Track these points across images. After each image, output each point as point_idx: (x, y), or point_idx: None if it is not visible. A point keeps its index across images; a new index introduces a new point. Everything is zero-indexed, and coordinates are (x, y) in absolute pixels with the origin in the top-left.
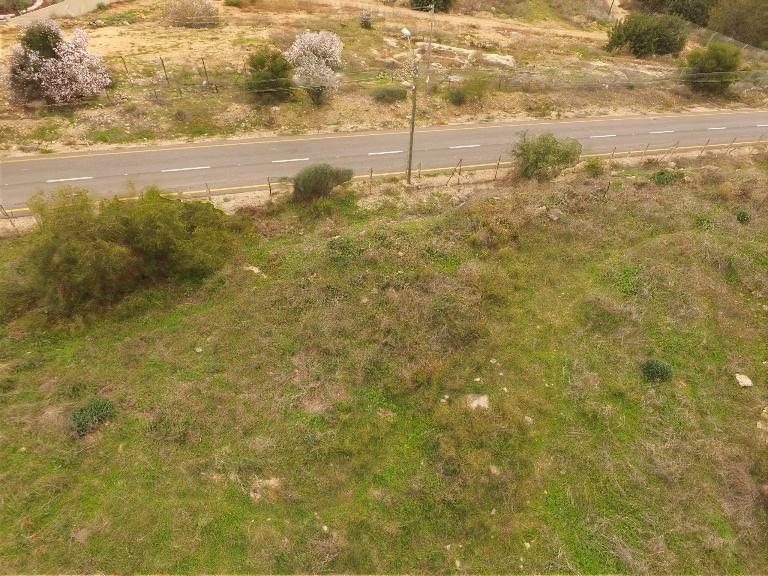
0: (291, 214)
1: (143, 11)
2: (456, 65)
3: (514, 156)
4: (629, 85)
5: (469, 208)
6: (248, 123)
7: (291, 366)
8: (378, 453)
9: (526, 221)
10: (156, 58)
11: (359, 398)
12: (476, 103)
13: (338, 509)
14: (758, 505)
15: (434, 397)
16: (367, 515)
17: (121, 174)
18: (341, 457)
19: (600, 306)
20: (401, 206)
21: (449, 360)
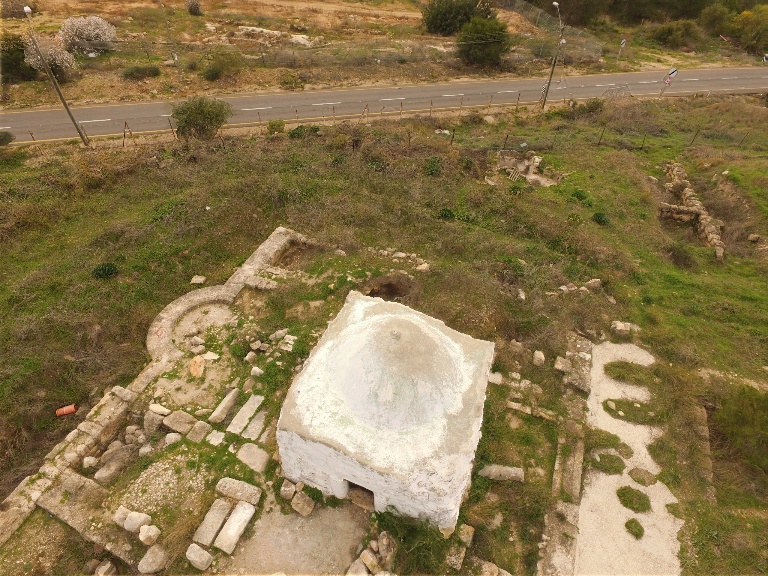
0: None
1: None
2: None
3: None
4: (401, 59)
5: None
6: None
7: None
8: None
9: (127, 168)
10: None
11: None
12: (231, 78)
13: None
14: None
15: None
16: None
17: None
18: None
19: None
20: (67, 164)
21: None
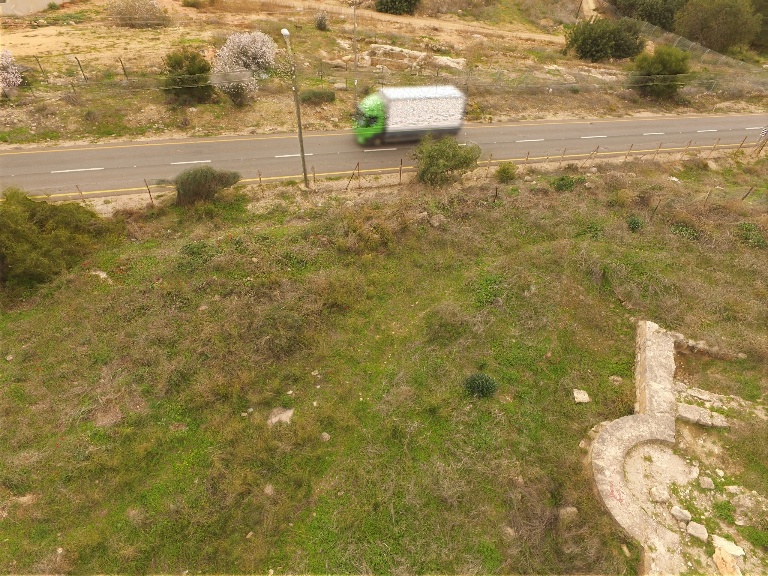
0: (173, 217)
1: (95, 11)
2: (404, 67)
3: (416, 160)
4: (574, 89)
5: (345, 213)
6: (161, 124)
7: (98, 376)
8: (151, 470)
9: (402, 227)
10: (85, 58)
11: (155, 411)
12: (408, 106)
13: (83, 530)
14: (550, 530)
15: (234, 411)
16: (106, 537)
17: (7, 175)
18: (109, 474)
19: (443, 316)
20: (293, 210)
21: (265, 371)
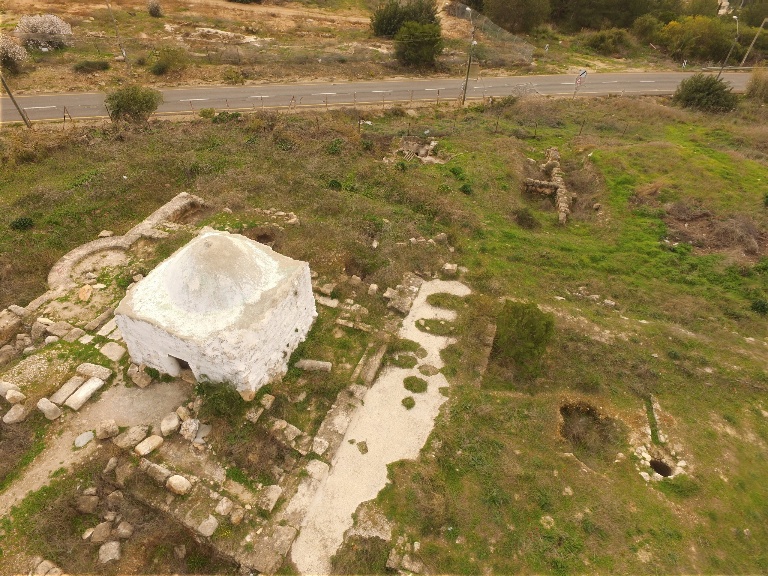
0: None
1: None
2: None
3: None
4: (341, 59)
5: None
6: None
7: None
8: None
9: (58, 145)
10: None
11: None
12: (177, 73)
13: None
14: None
15: None
16: None
17: None
18: None
19: None
20: None
21: None
